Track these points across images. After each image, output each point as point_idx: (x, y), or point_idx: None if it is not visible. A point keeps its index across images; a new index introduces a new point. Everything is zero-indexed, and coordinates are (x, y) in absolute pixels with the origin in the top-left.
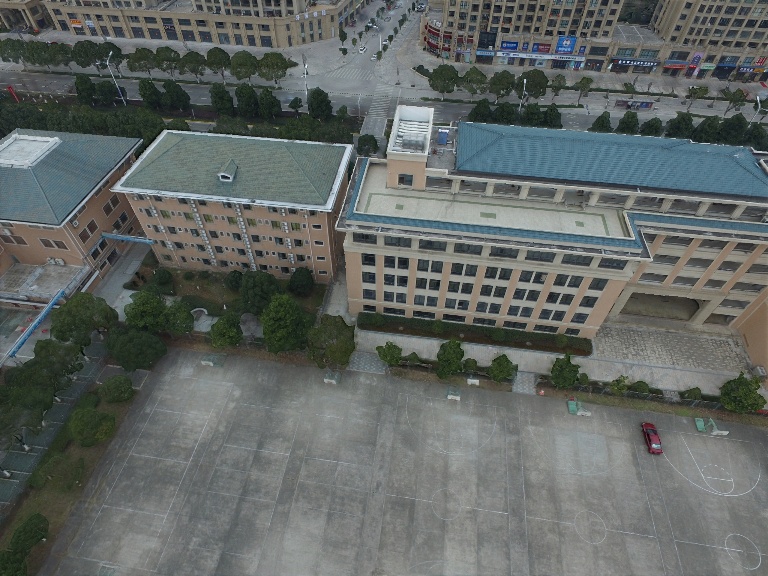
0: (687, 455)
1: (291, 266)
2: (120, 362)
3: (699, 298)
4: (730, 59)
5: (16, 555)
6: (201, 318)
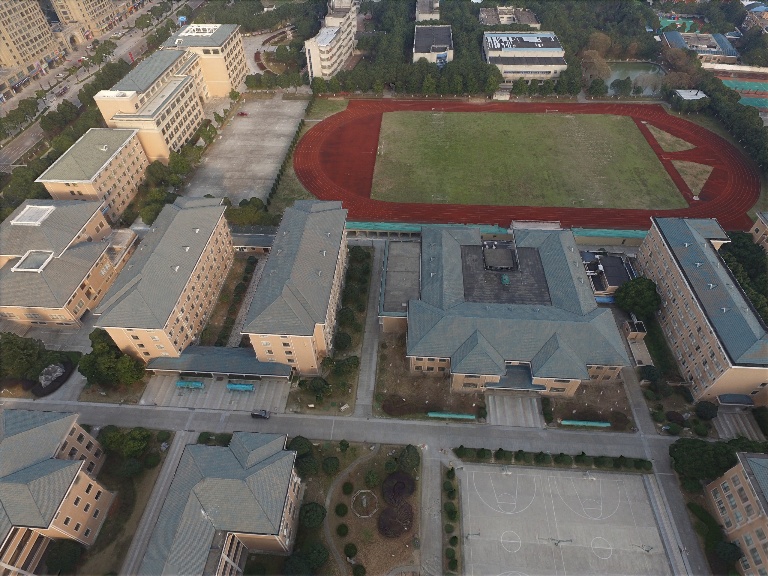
0: None
1: (141, 175)
2: None
3: None
4: (47, 58)
5: None
6: None
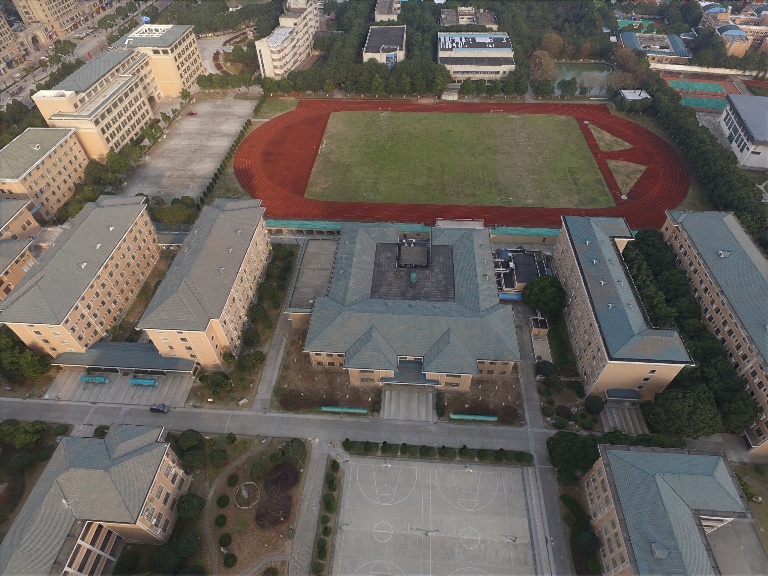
0: (198, 110)
1: (80, 173)
2: None
3: (151, 91)
4: (5, 58)
5: None
6: None
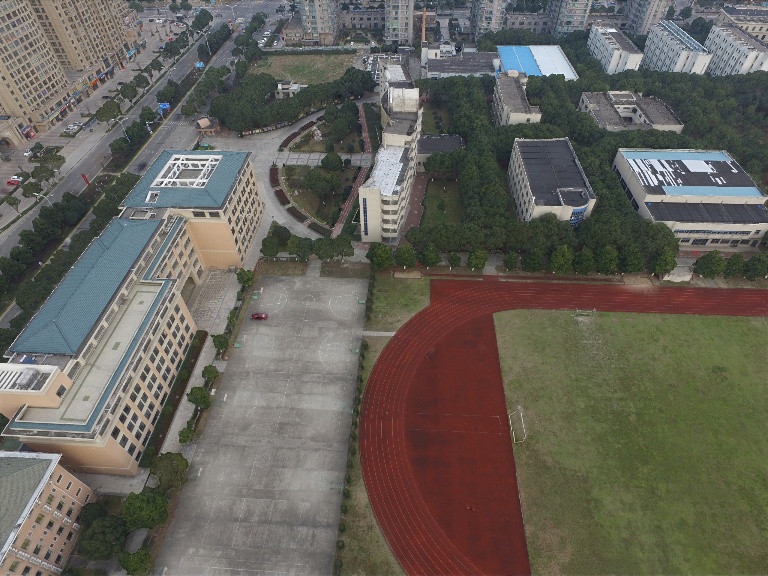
0: (268, 306)
1: (70, 527)
2: None
3: (189, 274)
4: None
5: None
6: None
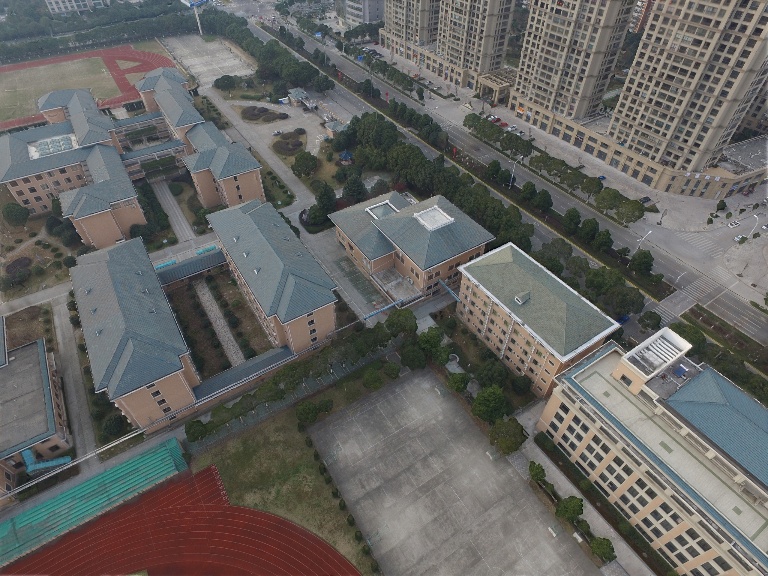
0: None
1: (523, 370)
2: (402, 357)
3: None
4: None
5: (317, 410)
6: (453, 361)
